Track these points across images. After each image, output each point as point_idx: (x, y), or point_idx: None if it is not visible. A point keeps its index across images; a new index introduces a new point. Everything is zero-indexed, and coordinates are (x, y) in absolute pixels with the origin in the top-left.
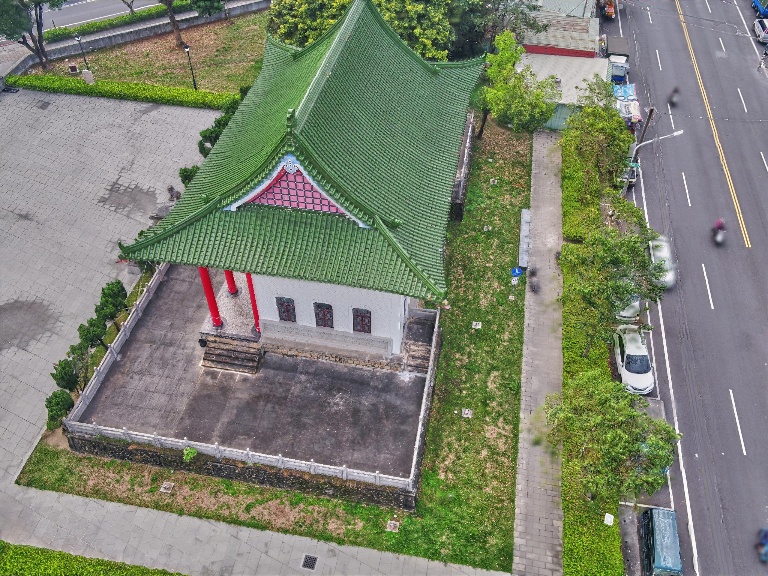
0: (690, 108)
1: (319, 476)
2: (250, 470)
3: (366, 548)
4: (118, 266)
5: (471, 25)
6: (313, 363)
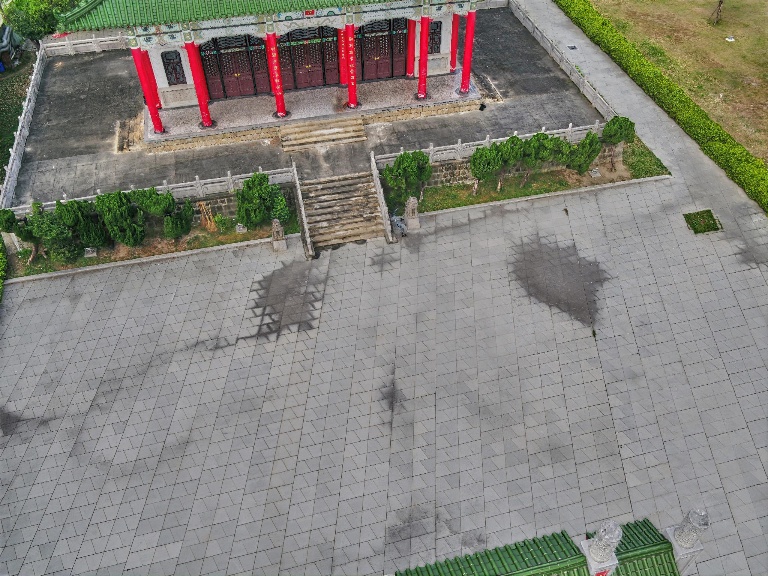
0: None
1: None
2: None
3: None
4: (416, 241)
5: None
6: None
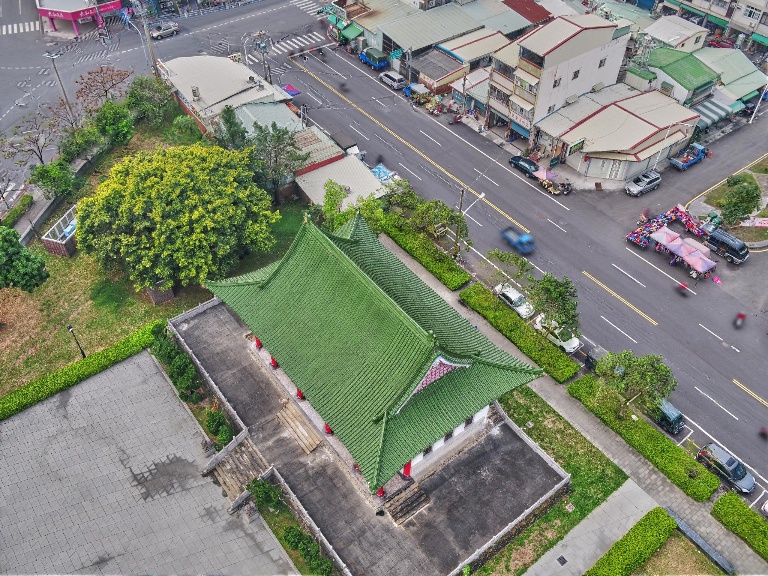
0: (413, 159)
1: (528, 517)
2: (494, 548)
3: (573, 529)
4: (235, 526)
5: (266, 180)
6: (448, 467)
